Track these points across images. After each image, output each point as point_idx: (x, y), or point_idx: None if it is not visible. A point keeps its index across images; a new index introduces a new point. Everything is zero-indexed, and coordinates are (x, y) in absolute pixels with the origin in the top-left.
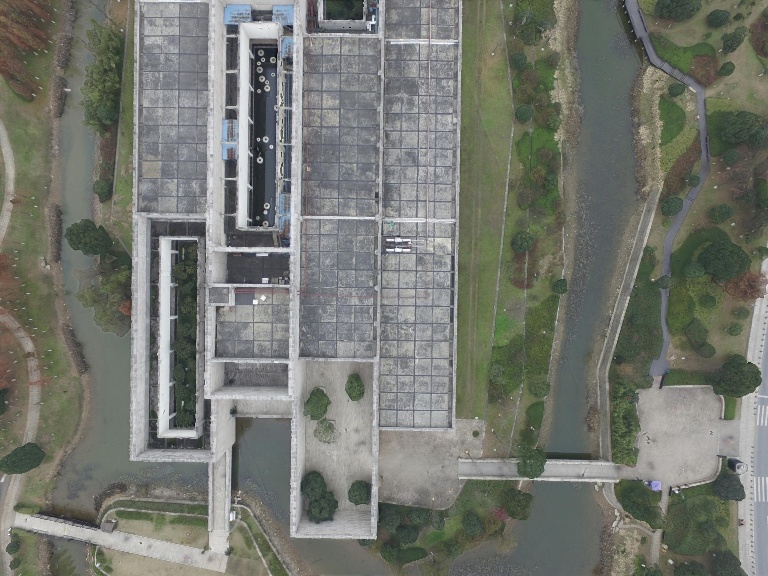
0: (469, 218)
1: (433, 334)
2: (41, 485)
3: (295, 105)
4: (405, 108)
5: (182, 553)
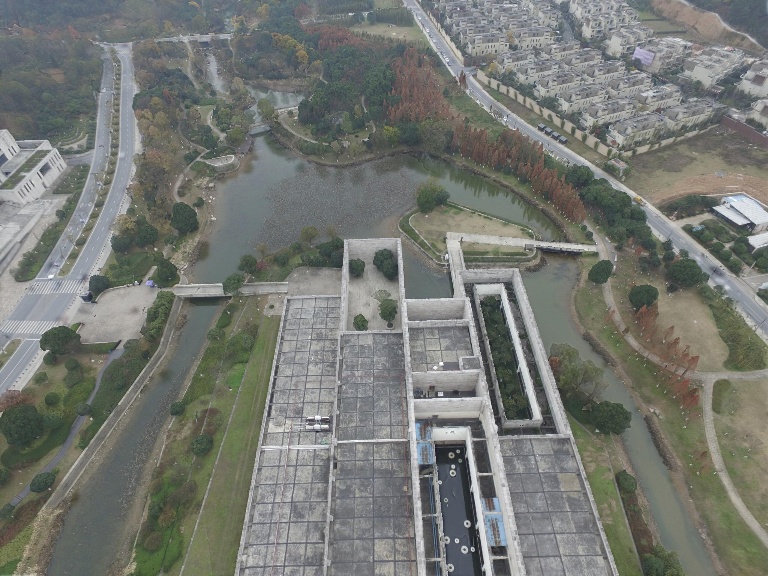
0: (249, 470)
1: (294, 357)
2: (587, 267)
3: (421, 548)
4: (300, 573)
5: (477, 239)
